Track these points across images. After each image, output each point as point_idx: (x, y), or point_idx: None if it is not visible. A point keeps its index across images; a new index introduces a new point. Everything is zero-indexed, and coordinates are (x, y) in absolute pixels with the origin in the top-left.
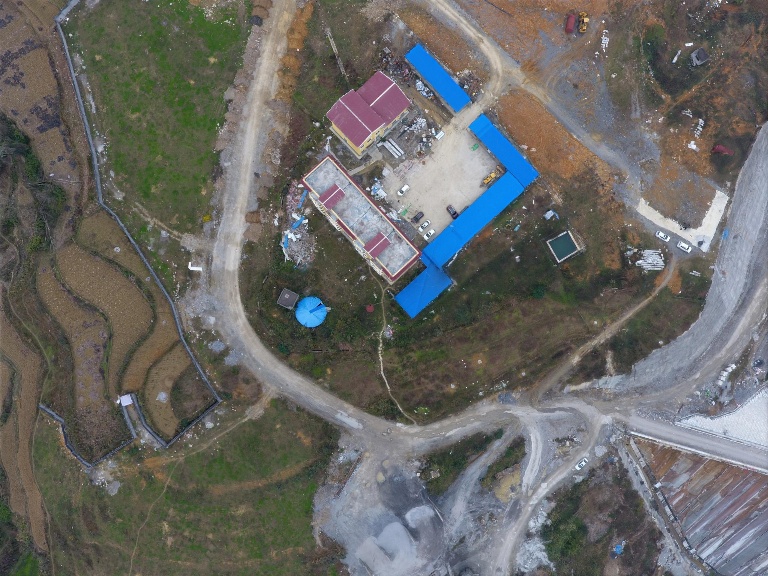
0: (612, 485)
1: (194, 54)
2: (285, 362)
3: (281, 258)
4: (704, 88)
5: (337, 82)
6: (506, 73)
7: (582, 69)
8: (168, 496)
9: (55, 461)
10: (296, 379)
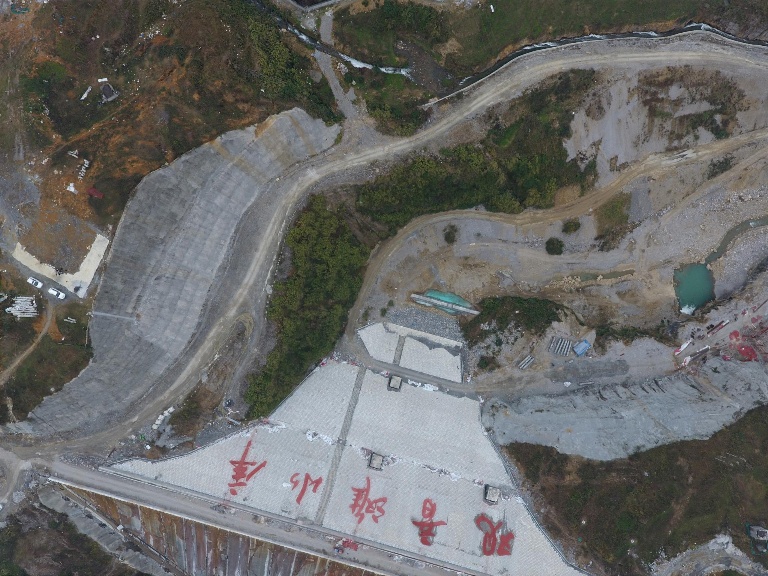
0: (48, 530)
1: None
2: None
3: None
4: (108, 126)
5: None
6: None
7: None
8: None
9: None
10: None
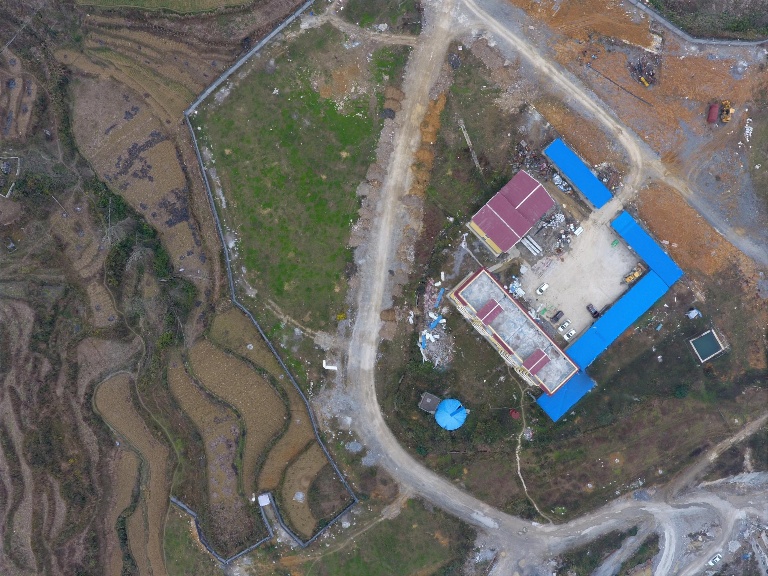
0: None
1: (326, 148)
2: (422, 462)
3: (420, 359)
4: None
5: (471, 176)
6: (646, 165)
7: (725, 160)
8: None
9: (187, 554)
10: (432, 479)
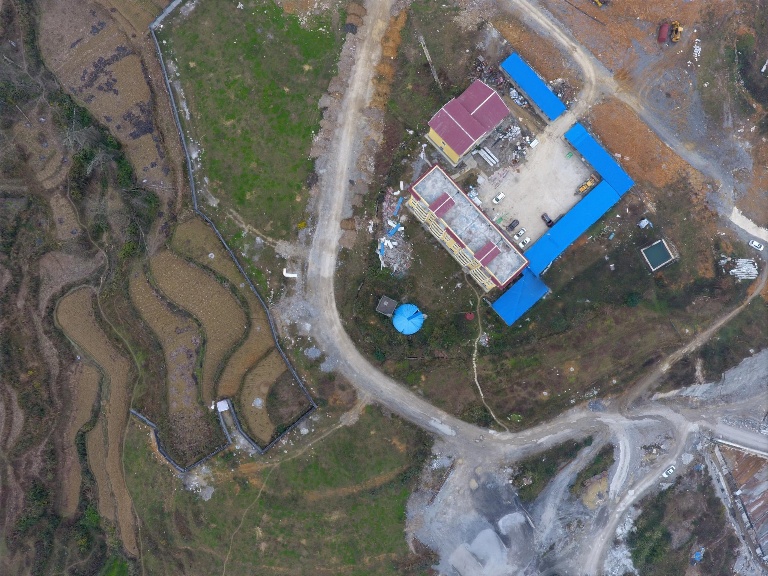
0: (696, 492)
1: (289, 61)
2: (380, 369)
3: (378, 265)
4: None
5: (431, 90)
6: (599, 82)
7: (674, 78)
8: (262, 502)
9: (146, 466)
10: (390, 386)
